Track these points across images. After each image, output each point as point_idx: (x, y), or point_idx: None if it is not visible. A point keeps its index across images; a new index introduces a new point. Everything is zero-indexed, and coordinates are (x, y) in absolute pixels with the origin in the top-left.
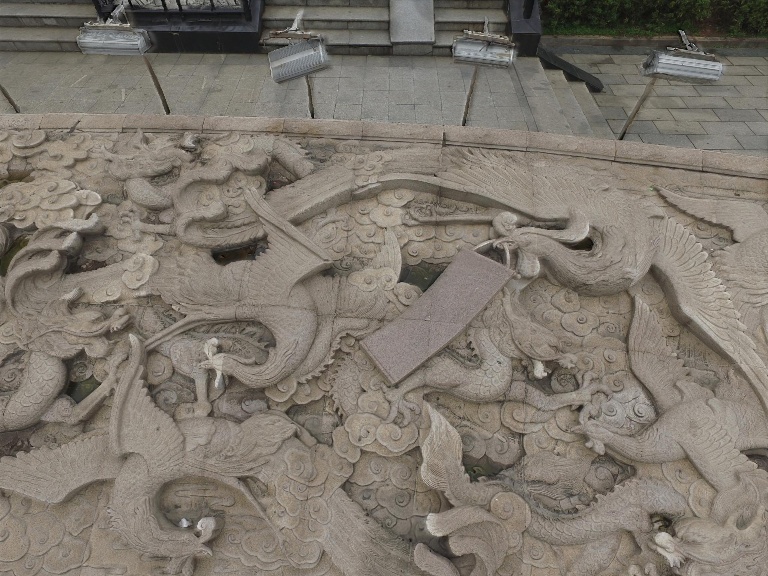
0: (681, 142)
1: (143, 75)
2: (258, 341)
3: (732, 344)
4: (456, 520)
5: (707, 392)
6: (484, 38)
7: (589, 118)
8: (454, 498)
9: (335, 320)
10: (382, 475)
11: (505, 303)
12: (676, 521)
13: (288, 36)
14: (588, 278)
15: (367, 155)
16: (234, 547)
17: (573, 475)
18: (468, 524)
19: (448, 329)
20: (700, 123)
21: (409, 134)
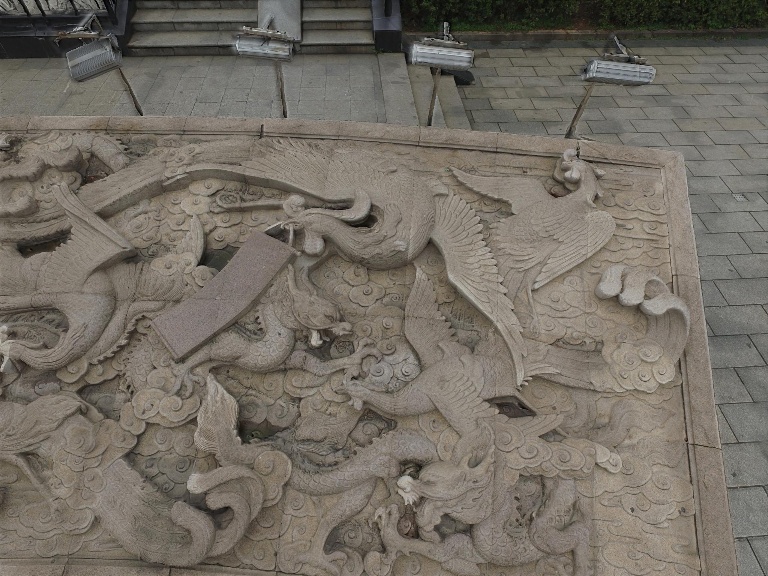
0: (536, 129)
1: (6, 80)
2: (55, 327)
3: (491, 305)
4: (214, 478)
5: (465, 349)
6: (263, 34)
7: (449, 109)
8: (223, 460)
9: (132, 304)
10: (166, 445)
11: (289, 279)
12: (424, 466)
13: (77, 36)
14: (365, 252)
15: (181, 148)
16: (12, 520)
17: (339, 432)
18: (225, 481)
19: (235, 306)
20: (557, 111)
21: (228, 127)
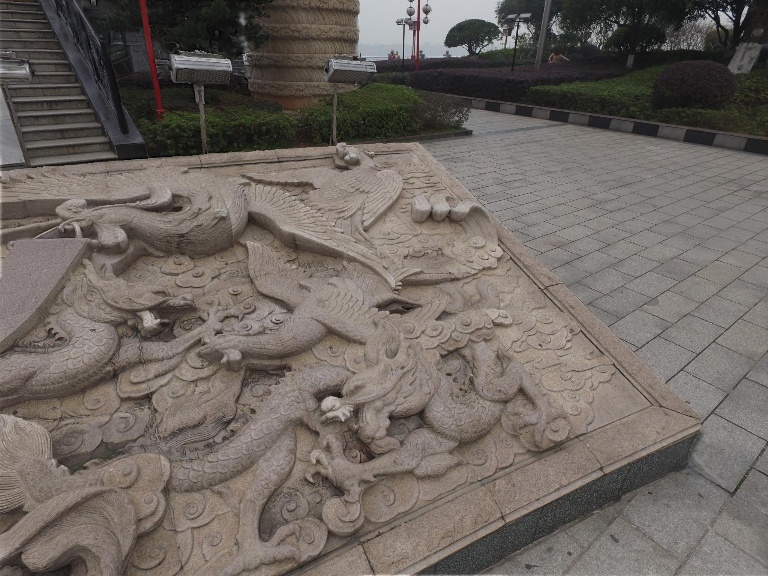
0: None
1: None
2: None
3: (334, 241)
4: (32, 520)
5: None
6: None
7: None
8: None
9: None
10: None
11: (88, 273)
12: None
13: None
14: (181, 227)
15: None
16: None
17: (221, 403)
18: (55, 515)
19: (9, 322)
20: None
21: None
